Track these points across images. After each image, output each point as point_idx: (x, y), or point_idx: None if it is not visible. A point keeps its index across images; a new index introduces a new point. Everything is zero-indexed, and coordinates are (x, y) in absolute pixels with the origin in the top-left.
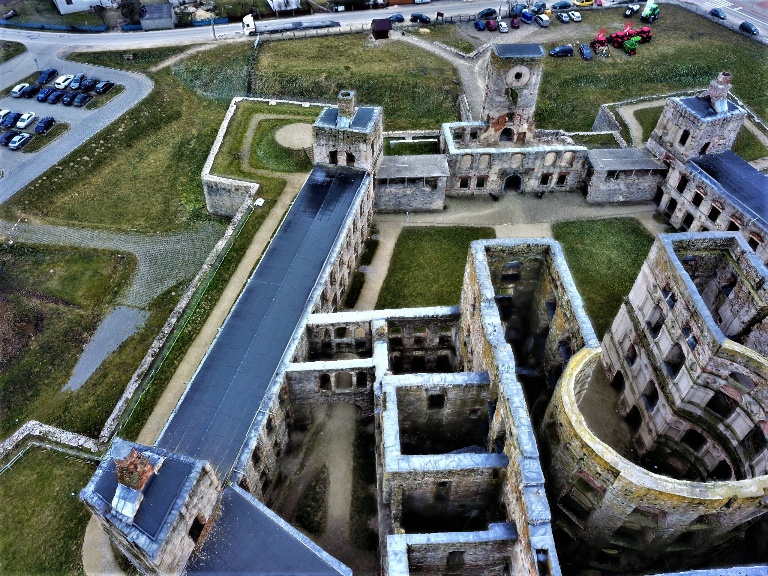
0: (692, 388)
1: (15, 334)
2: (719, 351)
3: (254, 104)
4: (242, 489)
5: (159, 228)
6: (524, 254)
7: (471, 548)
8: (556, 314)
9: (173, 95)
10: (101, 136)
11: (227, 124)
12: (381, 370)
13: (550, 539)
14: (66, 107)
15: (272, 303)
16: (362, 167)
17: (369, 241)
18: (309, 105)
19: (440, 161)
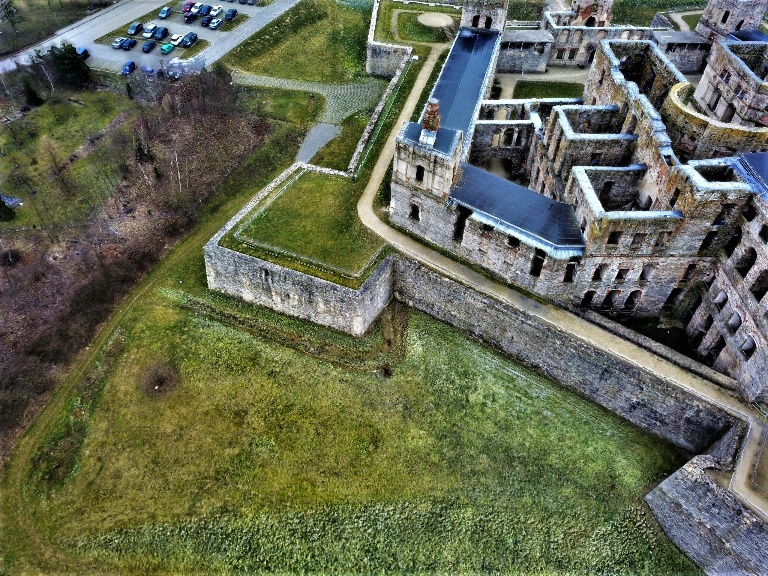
0: (741, 124)
1: (253, 134)
2: (760, 88)
3: (392, 3)
4: None
5: (334, 81)
6: (633, 50)
7: (618, 178)
8: (656, 81)
9: (319, 1)
10: (275, 23)
11: (376, 13)
12: (538, 124)
13: (671, 151)
14: (241, 5)
15: (458, 91)
16: (496, 29)
17: (494, 88)
18: (434, 5)
19: (546, 33)
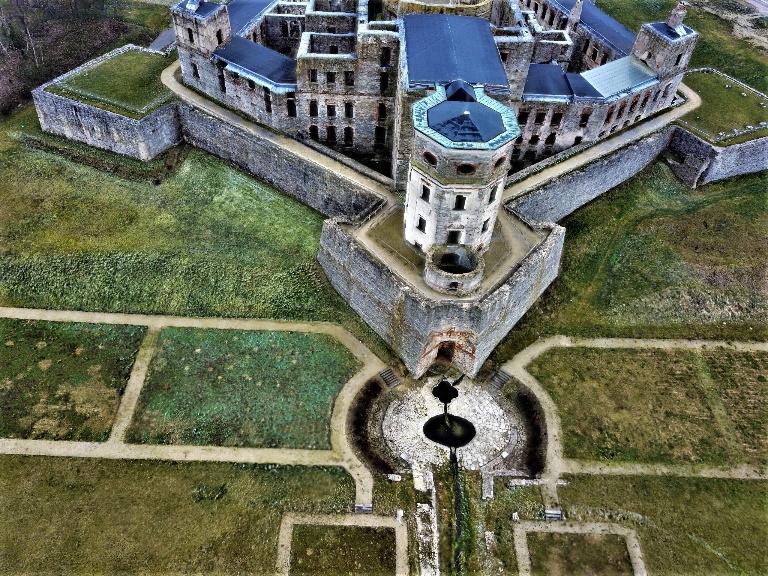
0: None
1: (111, 32)
2: None
3: None
4: None
5: None
6: None
7: (339, 43)
8: None
9: None
10: None
11: None
12: None
13: (366, 18)
14: None
15: None
16: None
17: None
18: None
19: None
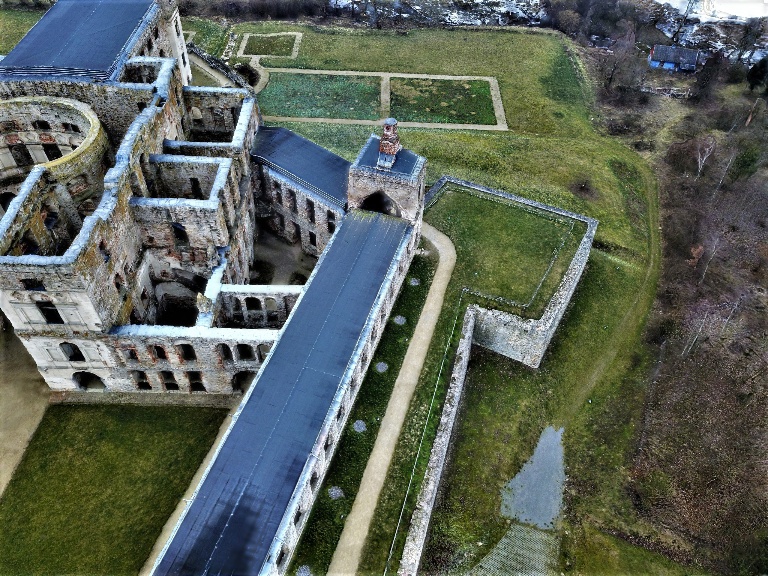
0: None
1: None
2: None
3: None
4: (337, 210)
5: None
6: None
7: None
8: None
9: None
10: None
11: None
12: (216, 277)
13: None
14: None
15: (315, 343)
16: None
17: None
18: None
19: None
